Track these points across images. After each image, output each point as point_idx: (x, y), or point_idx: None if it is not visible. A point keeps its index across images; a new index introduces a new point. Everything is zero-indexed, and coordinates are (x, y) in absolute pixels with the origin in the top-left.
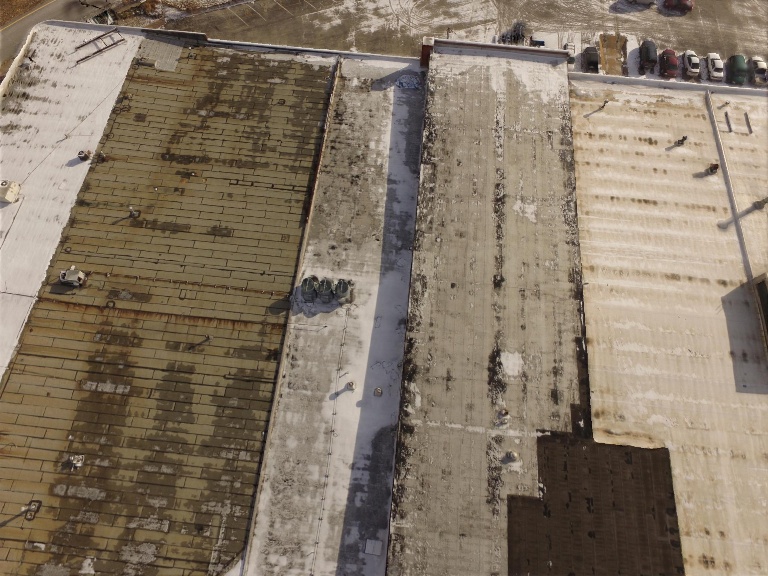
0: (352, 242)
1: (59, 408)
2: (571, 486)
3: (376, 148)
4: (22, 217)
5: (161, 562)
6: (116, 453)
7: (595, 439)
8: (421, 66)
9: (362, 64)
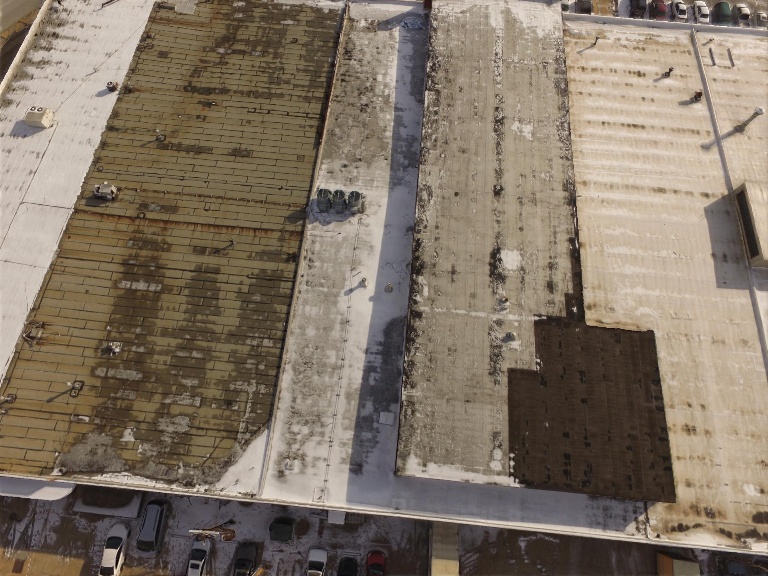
0: (362, 161)
1: (97, 303)
2: (565, 361)
3: (383, 80)
4: (57, 140)
5: (194, 431)
6: (150, 341)
7: None
8: (424, 8)
9: (369, 7)
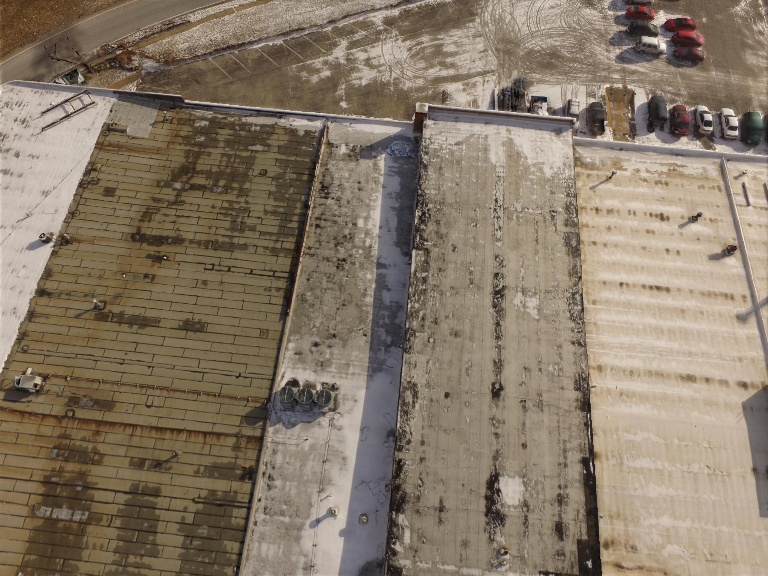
0: (337, 338)
1: (8, 539)
2: None
3: (365, 226)
4: None
5: None
6: None
7: (604, 575)
8: (414, 131)
9: (351, 128)
